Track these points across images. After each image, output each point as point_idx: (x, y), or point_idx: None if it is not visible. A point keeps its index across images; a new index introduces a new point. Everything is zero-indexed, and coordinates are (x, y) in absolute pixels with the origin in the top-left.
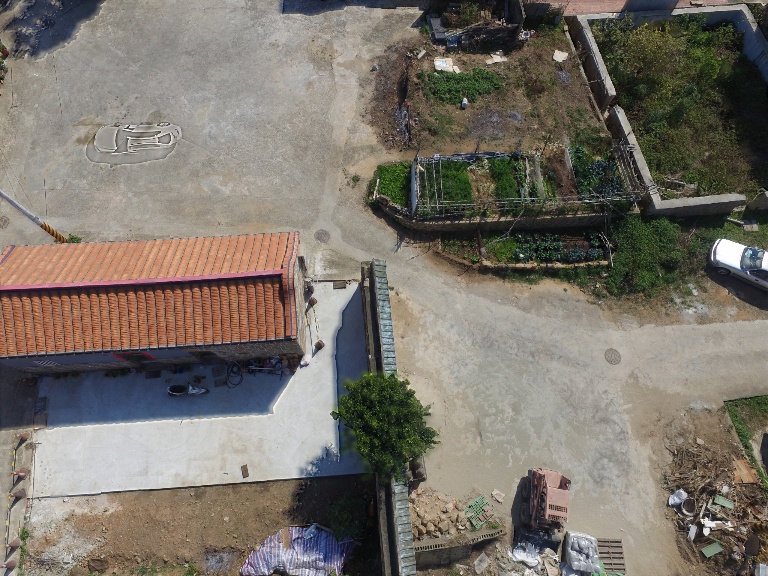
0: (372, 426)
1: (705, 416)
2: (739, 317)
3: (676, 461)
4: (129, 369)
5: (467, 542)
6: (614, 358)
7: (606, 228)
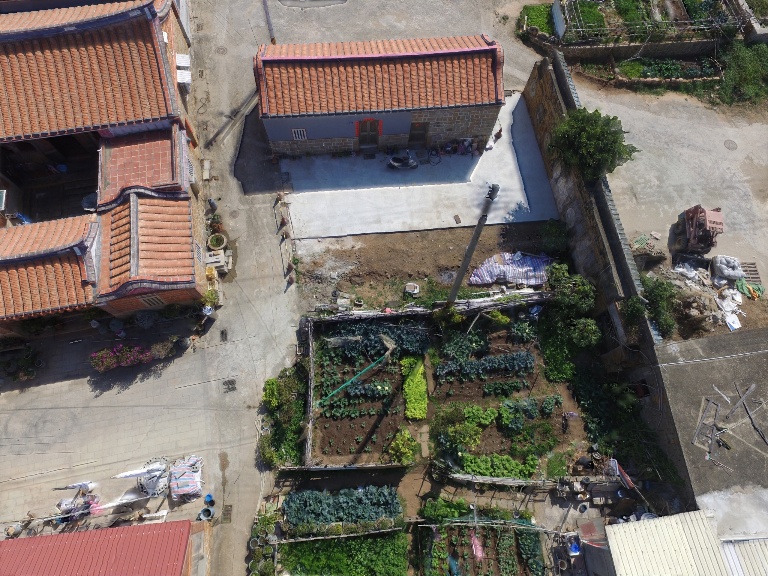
0: (595, 134)
1: None
2: None
3: None
4: (351, 152)
5: (646, 251)
6: (732, 146)
7: (716, 52)
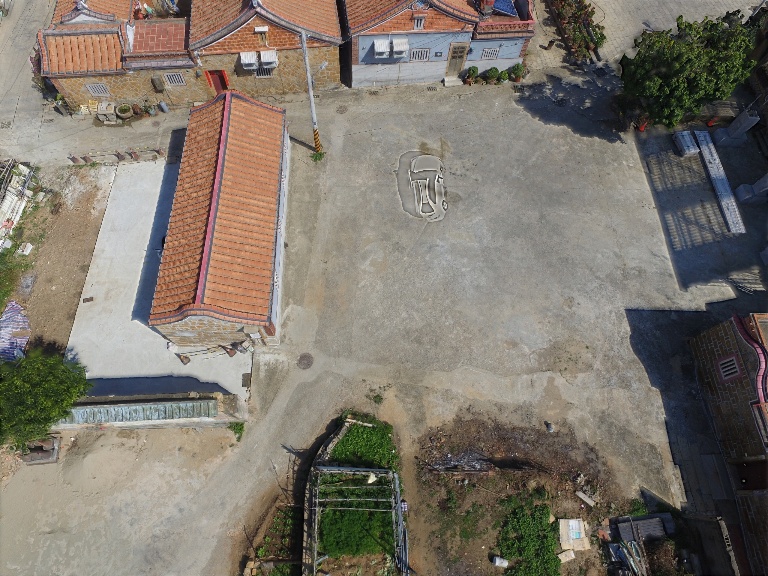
0: None
1: None
2: None
3: None
4: None
5: None
6: None
7: None
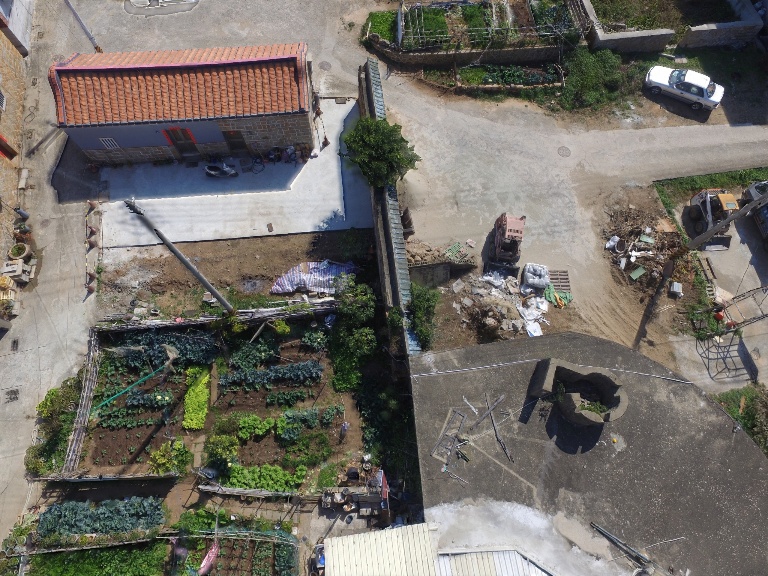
0: (370, 143)
1: (637, 191)
2: (668, 124)
3: (613, 220)
4: (173, 160)
5: (446, 260)
6: (565, 153)
7: (560, 58)
